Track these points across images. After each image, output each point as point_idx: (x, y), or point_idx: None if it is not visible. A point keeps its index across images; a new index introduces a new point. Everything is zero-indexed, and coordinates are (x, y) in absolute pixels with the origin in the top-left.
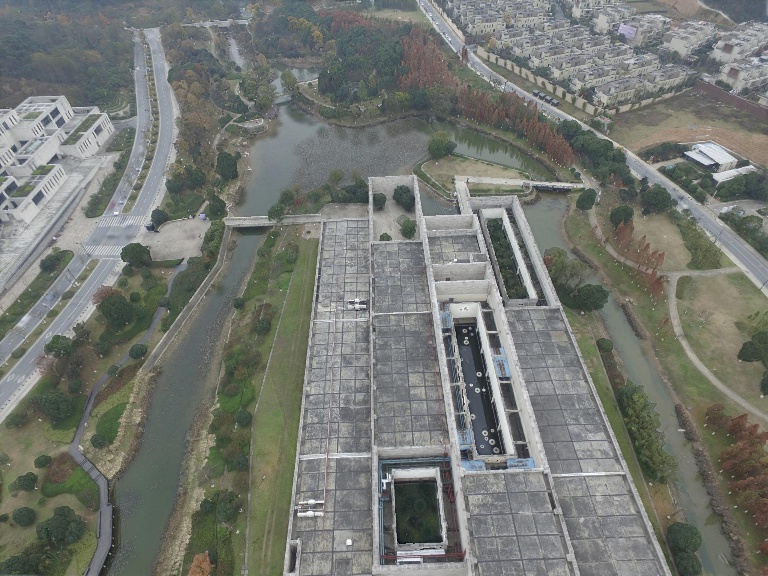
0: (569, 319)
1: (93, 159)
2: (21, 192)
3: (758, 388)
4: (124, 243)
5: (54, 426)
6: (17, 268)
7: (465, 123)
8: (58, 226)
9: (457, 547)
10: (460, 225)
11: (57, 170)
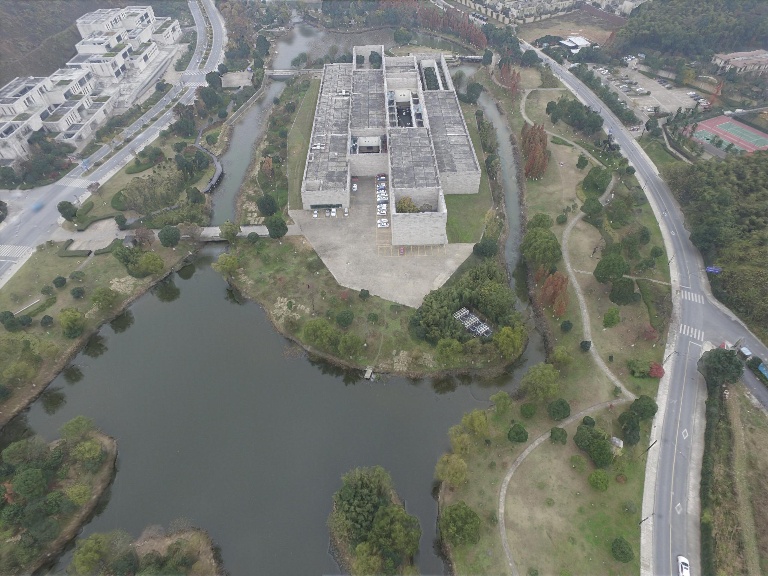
0: (463, 106)
1: (173, 45)
2: (136, 53)
3: None
4: (202, 81)
5: (184, 138)
6: (142, 89)
7: (423, 31)
8: (160, 73)
9: None
10: None
11: (154, 45)
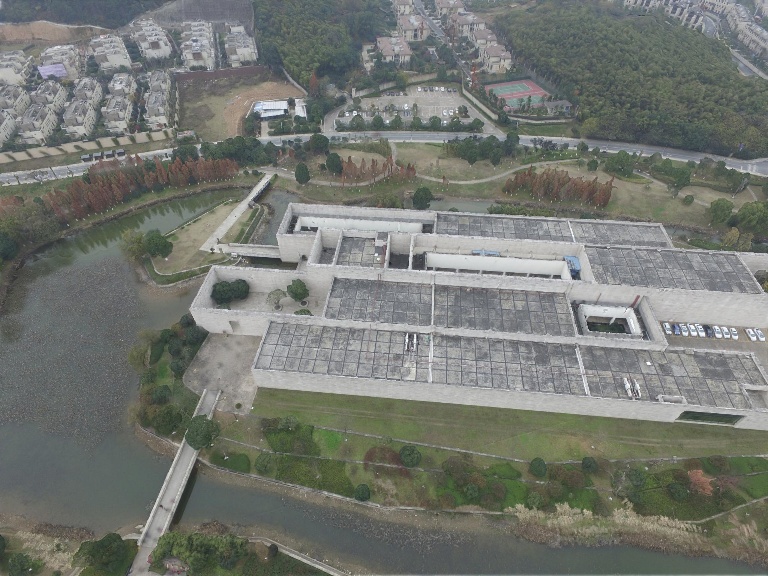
0: None
1: None
2: None
3: (488, 168)
4: None
5: None
6: None
7: (88, 224)
8: None
9: None
10: (319, 246)
11: None
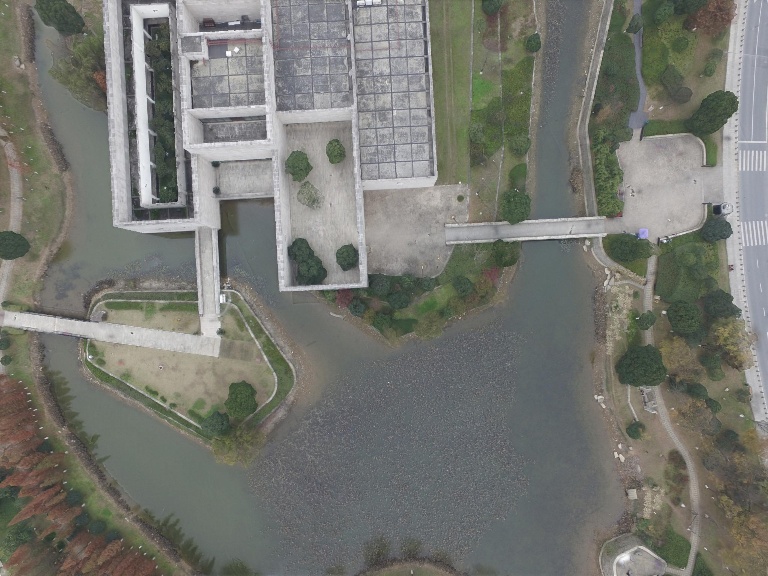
0: None
1: None
2: None
3: None
4: (749, 177)
5: None
6: None
7: (180, 567)
8: None
9: None
10: None
11: None
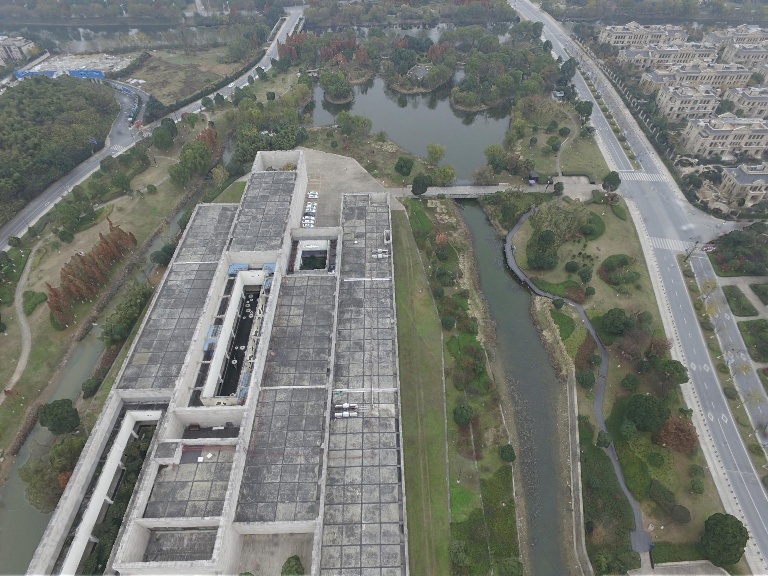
0: None
1: None
2: None
3: None
4: None
5: None
6: None
7: None
8: None
9: (294, 248)
10: None
11: None
